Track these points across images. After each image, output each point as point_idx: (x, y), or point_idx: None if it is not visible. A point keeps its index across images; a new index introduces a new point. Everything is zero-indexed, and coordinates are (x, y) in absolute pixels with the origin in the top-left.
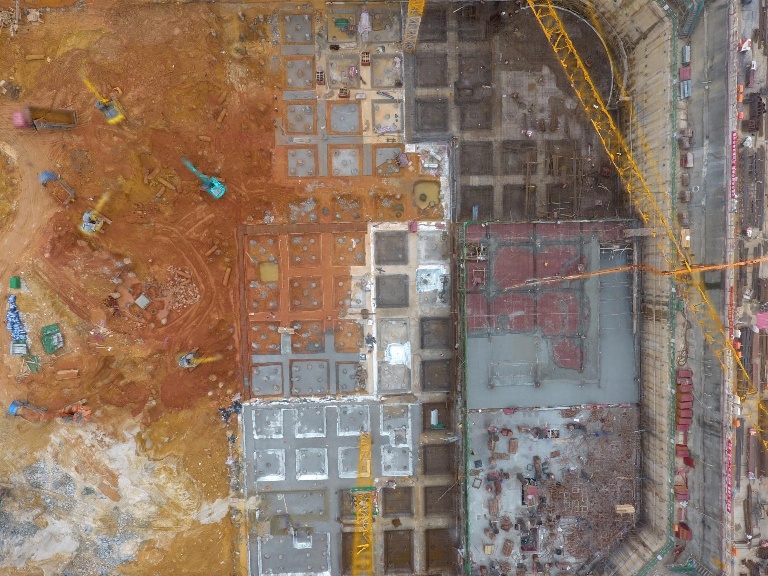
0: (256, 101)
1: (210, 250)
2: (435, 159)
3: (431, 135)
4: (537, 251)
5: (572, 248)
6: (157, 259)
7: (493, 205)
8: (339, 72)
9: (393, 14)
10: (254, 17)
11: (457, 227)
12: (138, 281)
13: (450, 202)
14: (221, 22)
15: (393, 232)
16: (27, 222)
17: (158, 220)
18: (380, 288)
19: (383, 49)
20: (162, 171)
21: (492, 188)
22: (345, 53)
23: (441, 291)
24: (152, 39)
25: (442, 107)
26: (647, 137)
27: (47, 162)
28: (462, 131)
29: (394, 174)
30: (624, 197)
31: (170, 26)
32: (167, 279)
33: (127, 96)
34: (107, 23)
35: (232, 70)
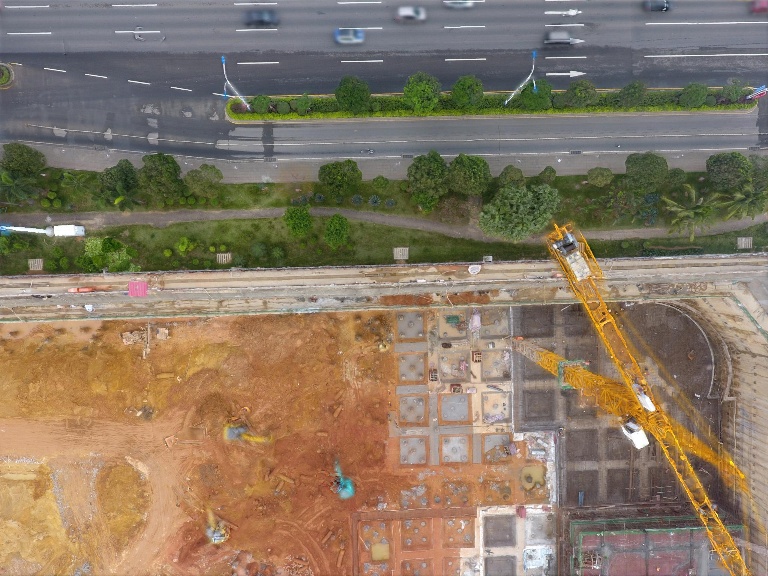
0: (371, 397)
1: (326, 537)
2: (542, 445)
3: (538, 424)
4: (649, 556)
5: (683, 553)
6: (275, 548)
7: (598, 488)
8: (450, 365)
9: (502, 310)
10: (369, 318)
11: (564, 512)
12: (253, 560)
13: (556, 486)
14: (338, 323)
15: (501, 515)
16: (157, 531)
17: (279, 517)
18: (488, 567)
19: (493, 345)
20: (282, 469)
21: (597, 473)
22: (456, 349)
23: (547, 568)
24: (277, 356)
25: (548, 396)
26: (756, 450)
27: (177, 475)
28: (568, 420)
29: (502, 459)
30: (725, 484)
31: (293, 339)
32: (284, 564)
33: (255, 414)
34: (232, 336)
35: (348, 369)
